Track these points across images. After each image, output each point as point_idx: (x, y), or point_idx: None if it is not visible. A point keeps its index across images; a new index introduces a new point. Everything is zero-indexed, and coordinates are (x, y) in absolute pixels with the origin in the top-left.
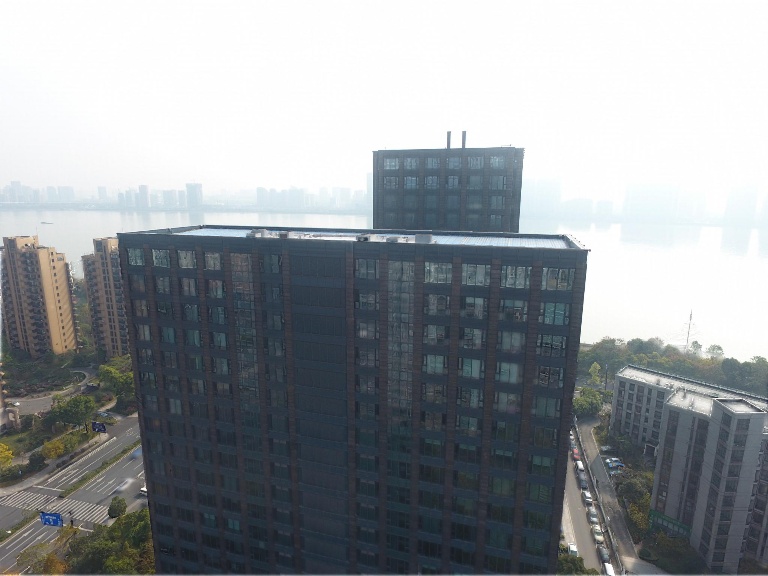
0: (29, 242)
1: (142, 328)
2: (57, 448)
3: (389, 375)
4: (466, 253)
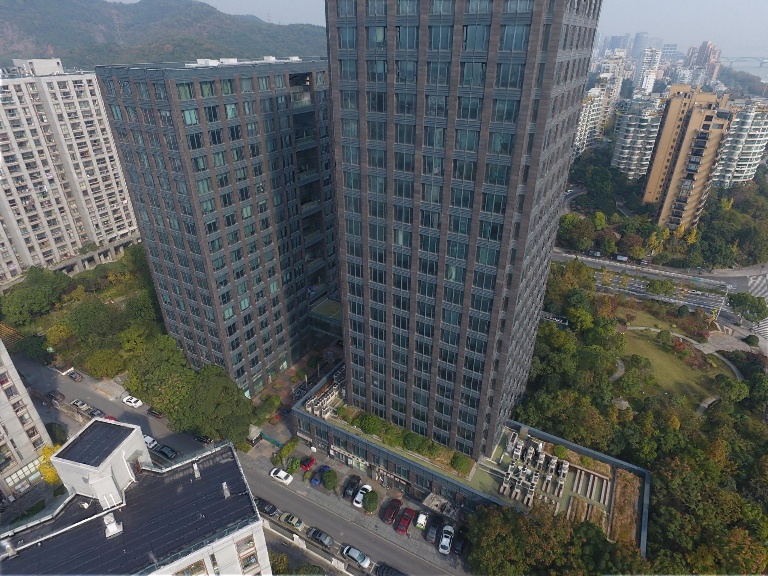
0: (683, 90)
1: None
2: None
3: None
4: None
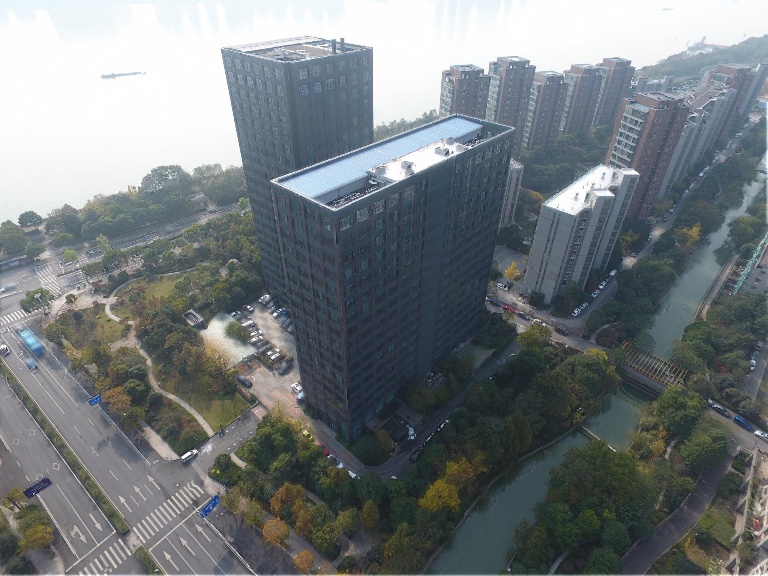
0: None
1: (348, 272)
2: (44, 531)
3: (460, 216)
4: (488, 144)
